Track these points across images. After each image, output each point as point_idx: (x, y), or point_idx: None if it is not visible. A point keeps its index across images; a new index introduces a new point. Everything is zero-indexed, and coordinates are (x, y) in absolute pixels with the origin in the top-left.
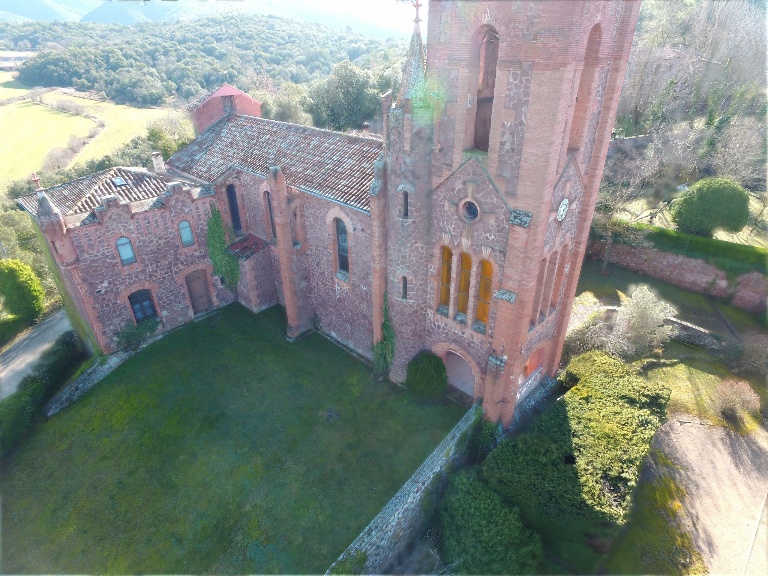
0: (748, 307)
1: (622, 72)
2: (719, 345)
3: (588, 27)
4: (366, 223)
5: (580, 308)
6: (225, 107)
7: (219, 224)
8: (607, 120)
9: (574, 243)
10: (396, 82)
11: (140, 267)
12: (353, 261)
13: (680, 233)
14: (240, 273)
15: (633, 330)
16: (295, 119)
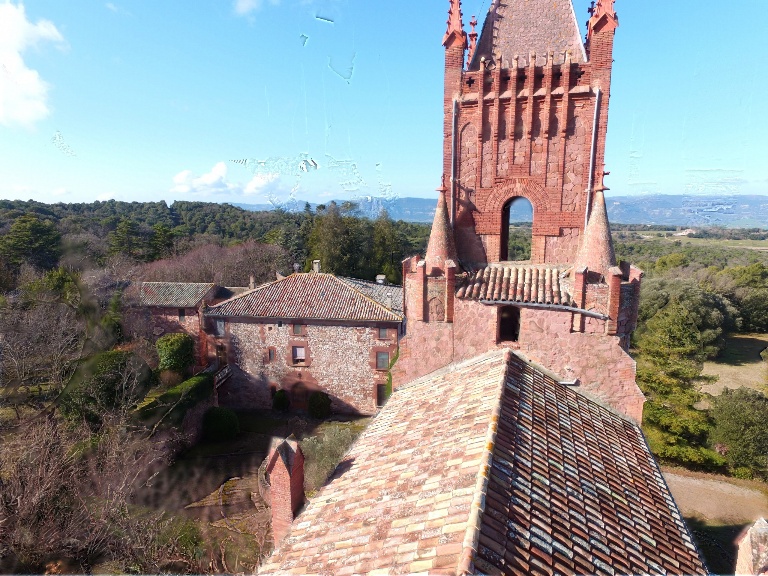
0: (194, 441)
1: None
2: None
3: None
4: None
5: None
6: None
7: None
8: None
9: None
10: None
11: None
12: None
13: None
14: None
15: None
16: None
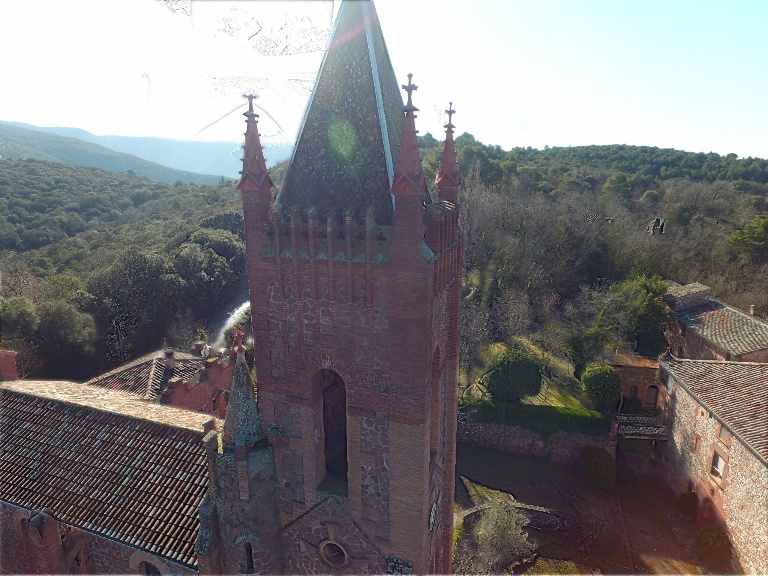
0: (564, 461)
1: (457, 366)
2: (562, 525)
3: None
4: (192, 572)
5: None
6: None
7: None
8: (453, 410)
9: (443, 526)
10: (195, 261)
11: None
12: None
13: (496, 403)
14: None
15: (497, 548)
16: (69, 327)
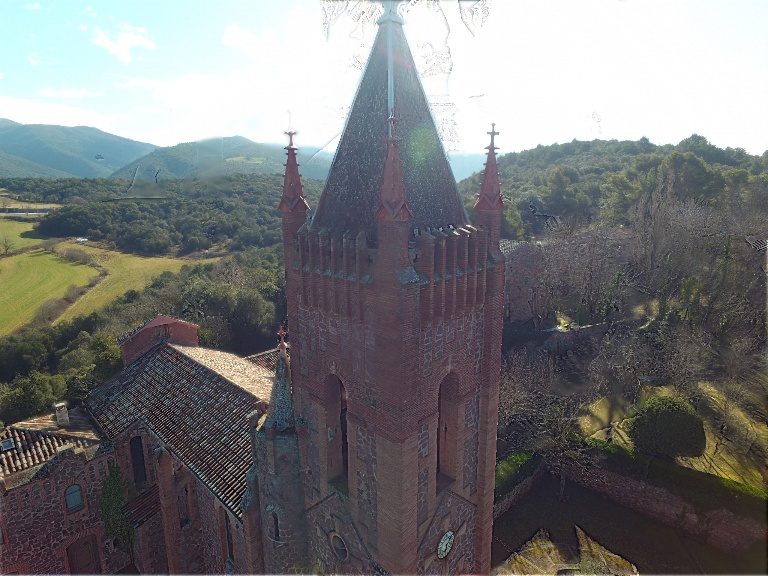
0: (726, 549)
1: (494, 396)
2: None
3: (436, 383)
4: None
5: (531, 561)
6: (158, 335)
7: (117, 481)
8: (486, 442)
9: (474, 561)
10: None
11: (8, 548)
12: (238, 559)
13: (638, 455)
14: (135, 536)
15: None
16: (255, 311)
